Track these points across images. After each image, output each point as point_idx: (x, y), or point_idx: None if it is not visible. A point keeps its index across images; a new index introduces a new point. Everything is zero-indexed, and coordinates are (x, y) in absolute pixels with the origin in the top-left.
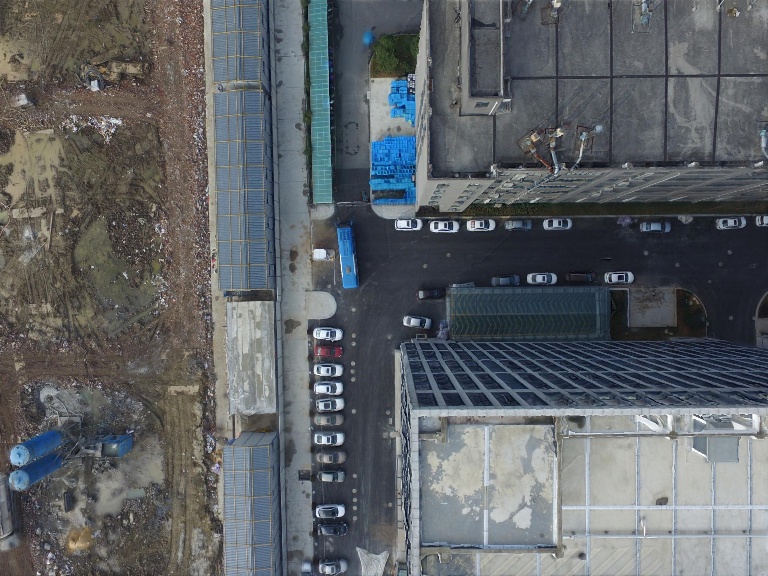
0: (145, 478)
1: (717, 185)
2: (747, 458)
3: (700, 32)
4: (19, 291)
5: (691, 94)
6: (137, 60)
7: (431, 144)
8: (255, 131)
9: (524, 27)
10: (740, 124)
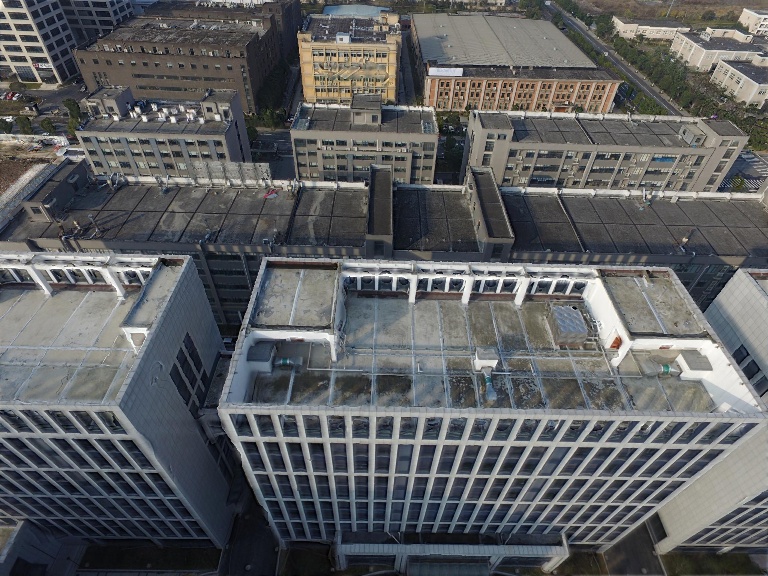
0: None
1: (231, 288)
2: (1, 317)
3: (193, 199)
4: None
5: (175, 219)
6: None
7: (3, 232)
8: None
9: (96, 194)
10: (199, 231)
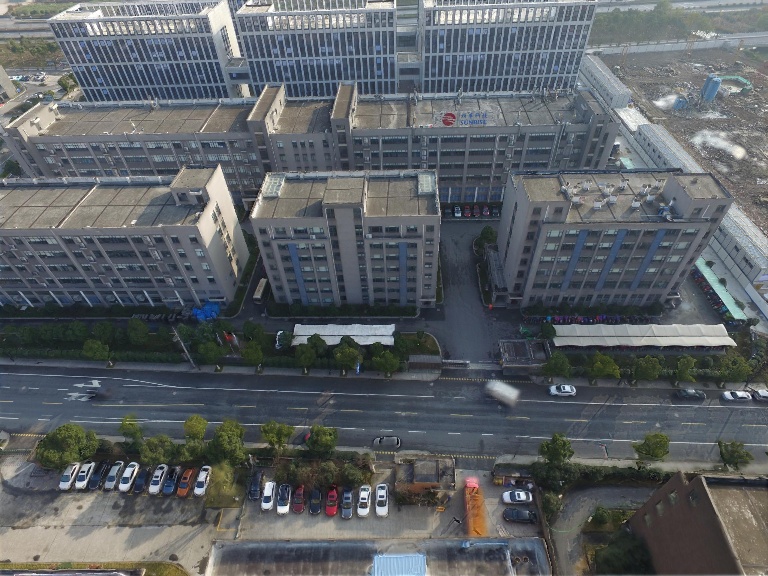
0: (661, 102)
1: None
2: None
3: None
4: (763, 138)
5: None
6: (766, 205)
7: None
8: (675, 162)
9: None
10: None
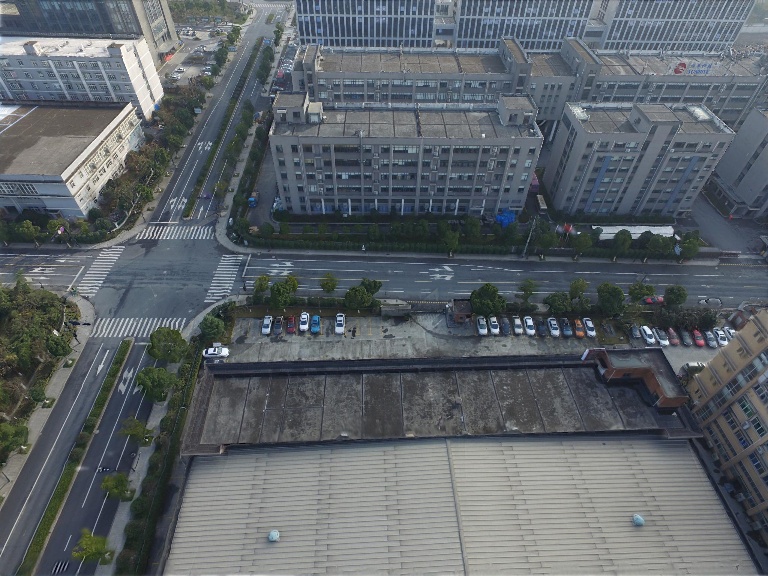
0: None
1: None
2: None
3: None
4: None
5: None
6: None
7: None
8: None
9: None
10: None
